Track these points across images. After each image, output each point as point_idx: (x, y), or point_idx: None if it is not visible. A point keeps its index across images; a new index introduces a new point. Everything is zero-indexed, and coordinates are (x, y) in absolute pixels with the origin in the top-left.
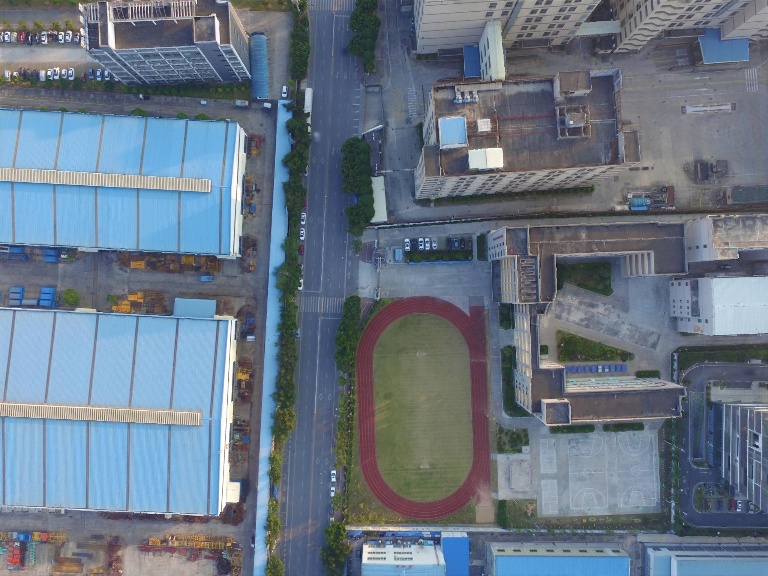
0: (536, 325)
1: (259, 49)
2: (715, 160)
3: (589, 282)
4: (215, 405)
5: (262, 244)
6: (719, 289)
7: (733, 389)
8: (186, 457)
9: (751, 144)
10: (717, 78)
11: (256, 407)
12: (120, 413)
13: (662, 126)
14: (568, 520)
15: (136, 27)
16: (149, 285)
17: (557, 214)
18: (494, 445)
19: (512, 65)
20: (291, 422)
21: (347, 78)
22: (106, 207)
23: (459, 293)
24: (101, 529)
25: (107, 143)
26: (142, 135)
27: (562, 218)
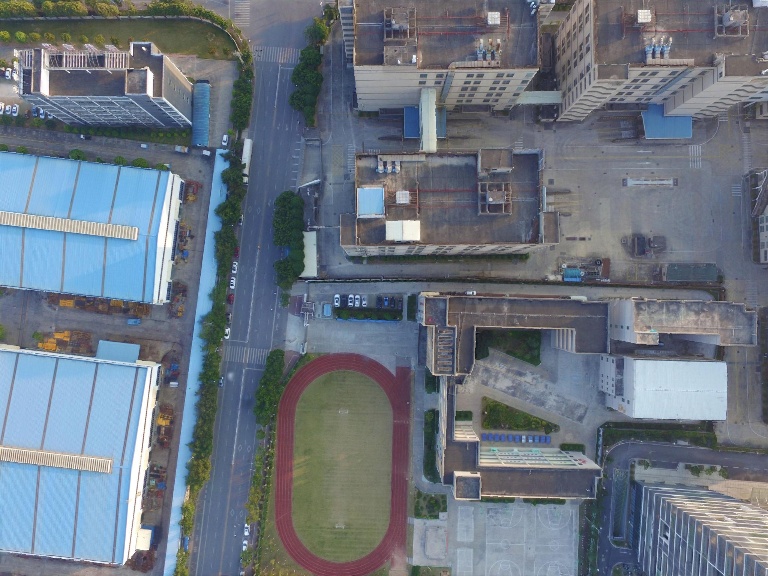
0: (453, 395)
1: (201, 97)
2: (653, 235)
3: (517, 351)
4: (127, 453)
5: (192, 290)
6: (641, 371)
7: (658, 469)
8: (94, 503)
9: (691, 221)
10: (660, 152)
11: (174, 454)
12: (31, 455)
13: (602, 197)
14: None
15: (71, 74)
16: (76, 324)
17: (490, 279)
18: (412, 509)
19: (454, 127)
20: (206, 473)
21: (288, 130)
22: (32, 248)
23: (386, 352)
24: (10, 567)
25: (39, 184)
26: (74, 178)
27: (495, 284)
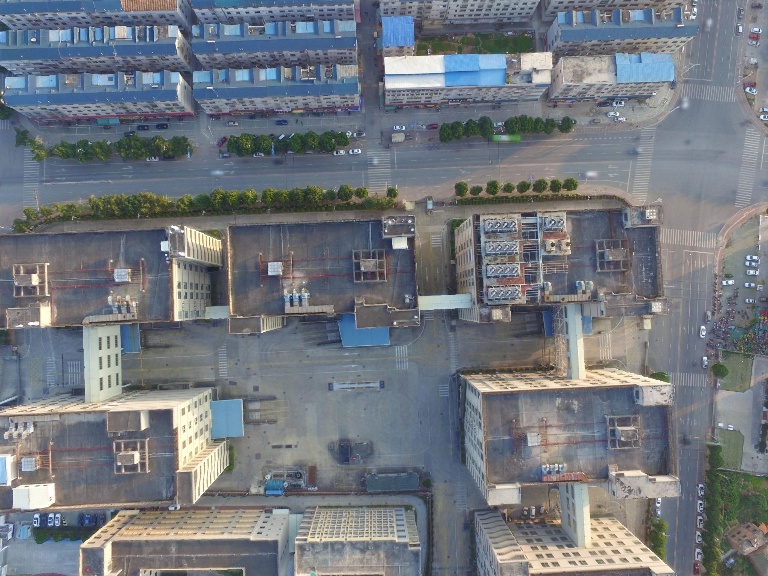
0: None
1: None
2: (361, 439)
3: None
4: None
5: None
6: None
7: None
8: None
9: (399, 424)
10: (366, 355)
11: None
12: None
13: (308, 403)
14: None
15: None
16: None
17: None
18: None
19: (157, 335)
20: None
21: None
22: None
23: None
24: None
25: None
26: None
27: None
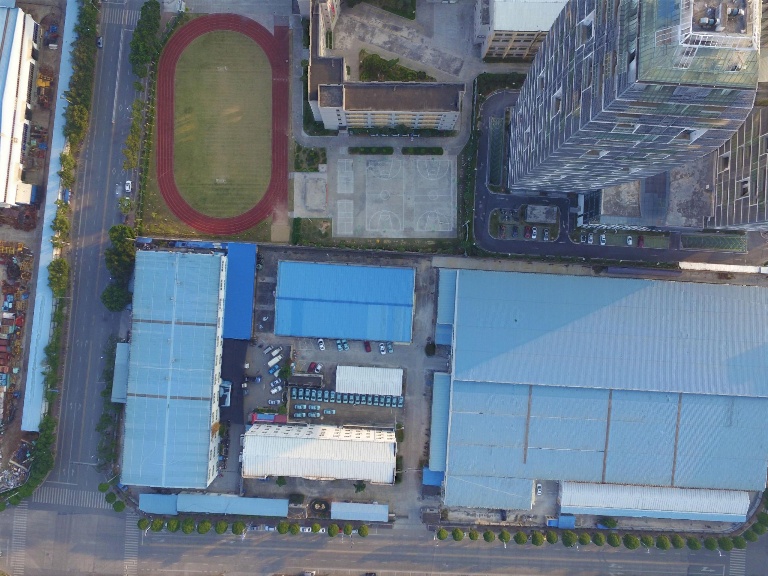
0: (318, 14)
1: None
2: None
3: None
4: None
5: None
6: None
7: None
8: None
9: None
10: None
11: None
12: None
13: None
14: (362, 241)
15: None
16: None
17: None
18: (292, 164)
19: None
20: (82, 121)
21: None
22: None
23: (264, 12)
24: None
25: None
26: None
27: None
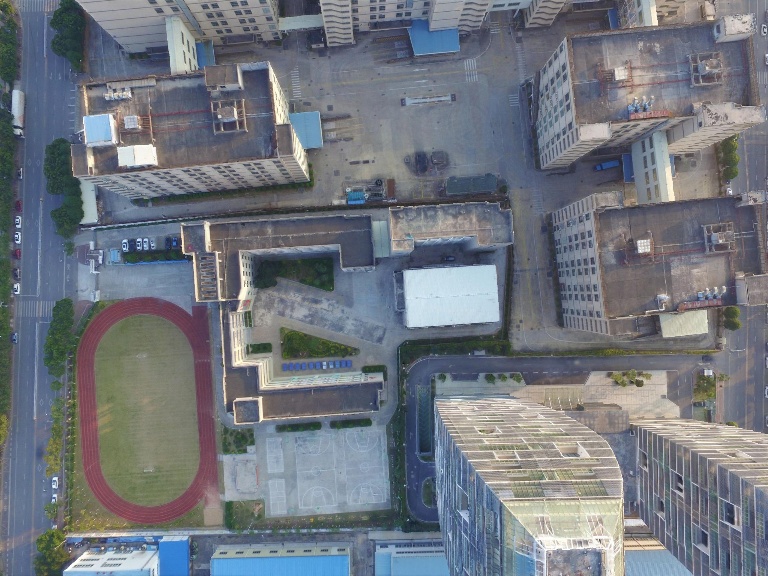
0: (229, 323)
1: None
2: None
3: (306, 278)
4: None
5: None
6: (411, 281)
7: (459, 381)
8: None
9: (472, 135)
10: (436, 69)
11: None
12: None
13: (382, 119)
14: (297, 520)
15: None
16: None
17: (276, 210)
18: (220, 446)
19: (229, 62)
20: (1, 429)
21: (62, 79)
22: None
23: (181, 293)
24: None
25: None
26: None
27: (282, 214)
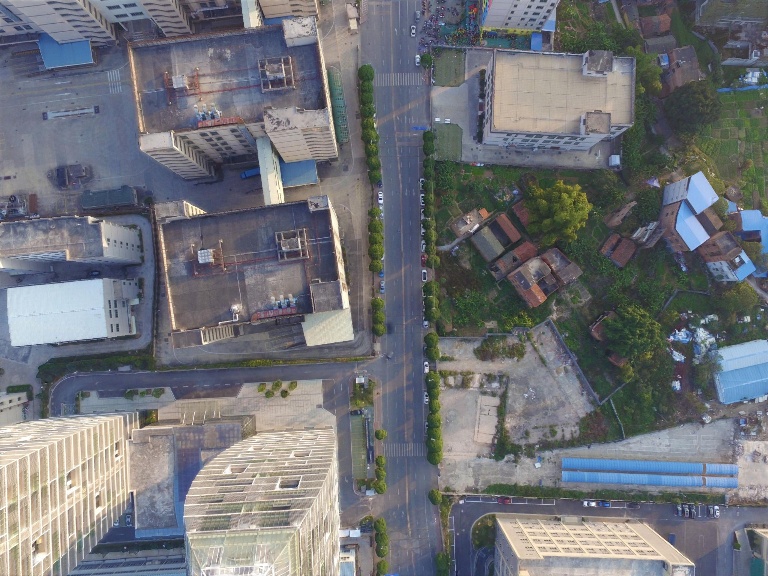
0: None
1: None
2: None
3: None
4: None
5: None
6: (14, 299)
7: (106, 399)
8: None
9: (116, 146)
10: (78, 82)
11: None
12: None
13: (23, 134)
14: None
15: None
16: None
17: None
18: None
19: None
20: None
21: None
22: None
23: None
24: None
25: None
26: None
27: None
